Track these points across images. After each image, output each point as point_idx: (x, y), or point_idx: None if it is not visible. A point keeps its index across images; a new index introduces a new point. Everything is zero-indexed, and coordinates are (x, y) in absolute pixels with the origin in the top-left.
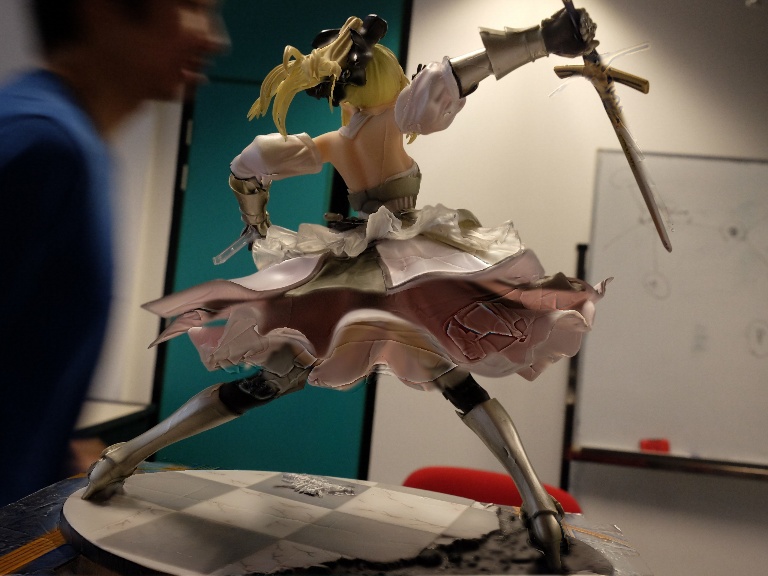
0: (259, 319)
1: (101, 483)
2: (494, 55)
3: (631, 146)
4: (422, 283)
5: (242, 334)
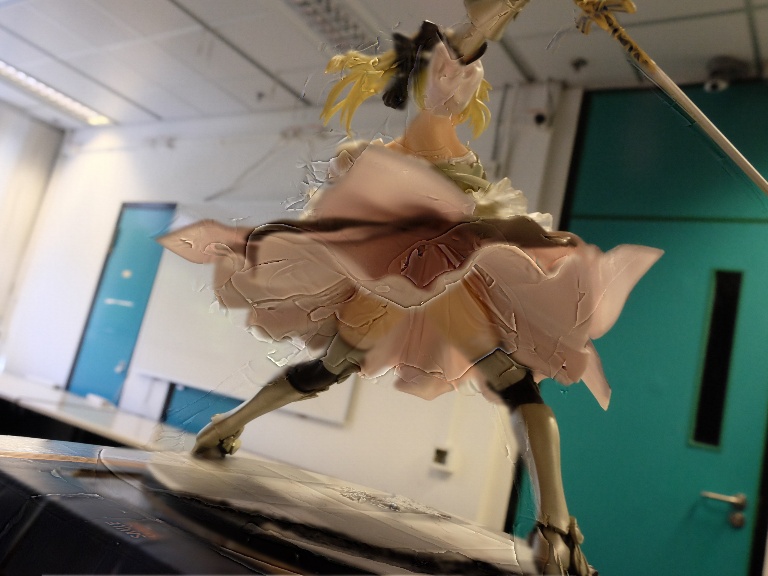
0: (203, 237)
1: (153, 432)
2: (470, 6)
3: (670, 105)
4: (321, 194)
5: (289, 314)
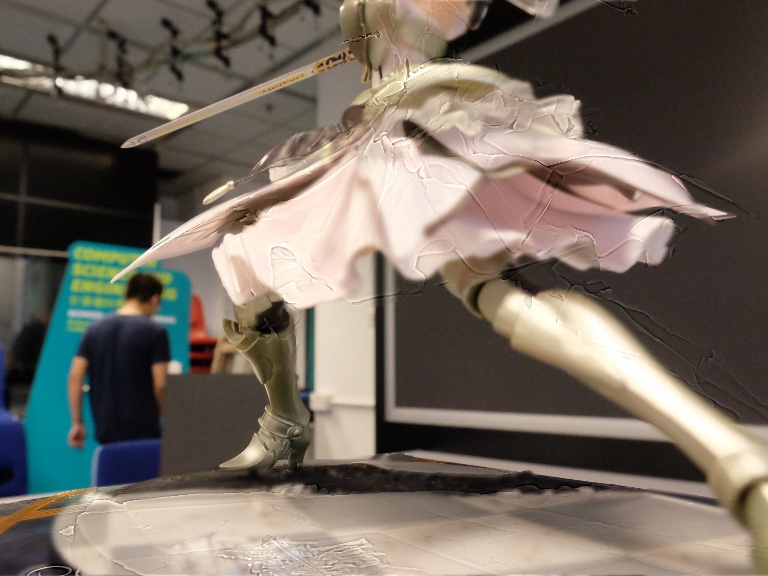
0: None
1: None
2: None
3: None
4: None
5: (589, 197)
